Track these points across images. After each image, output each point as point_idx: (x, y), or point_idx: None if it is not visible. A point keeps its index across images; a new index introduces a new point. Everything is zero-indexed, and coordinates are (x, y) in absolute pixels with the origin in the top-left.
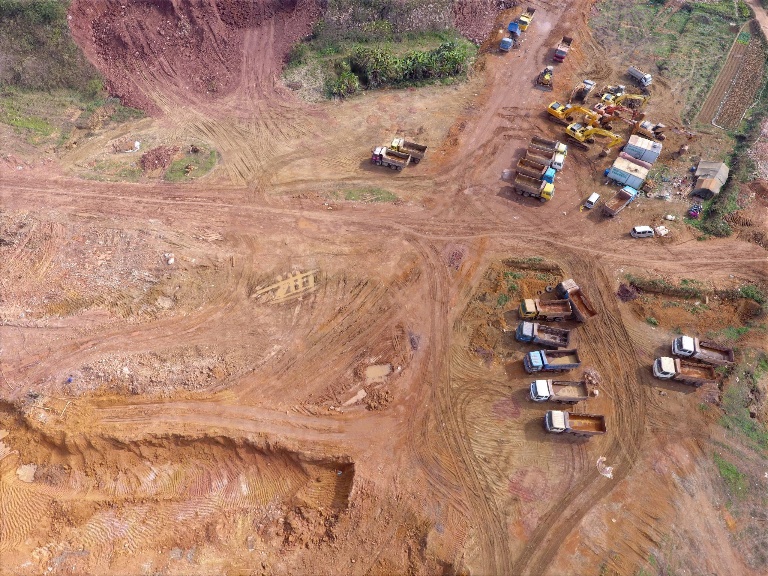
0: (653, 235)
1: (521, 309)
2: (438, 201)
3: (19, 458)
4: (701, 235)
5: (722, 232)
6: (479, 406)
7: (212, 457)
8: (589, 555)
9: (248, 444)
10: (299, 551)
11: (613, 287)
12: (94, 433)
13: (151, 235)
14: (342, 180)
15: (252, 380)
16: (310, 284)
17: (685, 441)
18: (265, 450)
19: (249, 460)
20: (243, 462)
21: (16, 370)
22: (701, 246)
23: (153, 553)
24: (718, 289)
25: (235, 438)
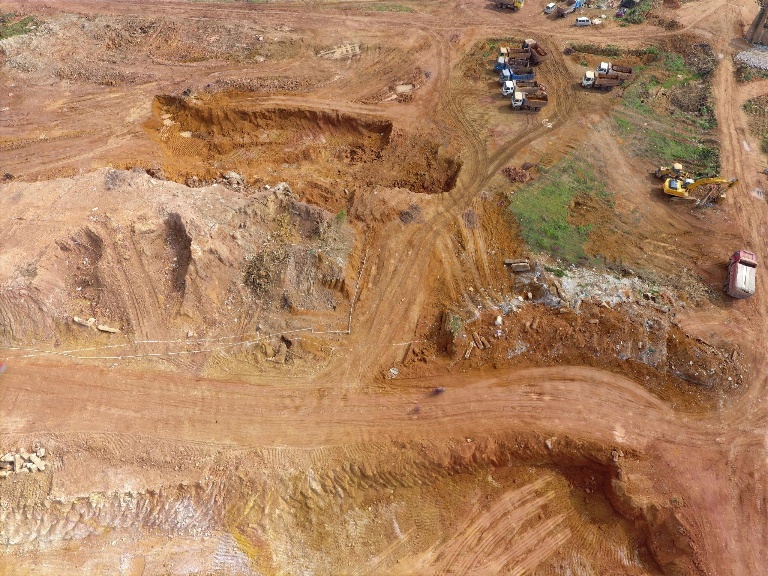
0: (590, 24)
1: (498, 54)
2: (442, 11)
3: (181, 127)
4: (623, 23)
5: (637, 20)
6: (470, 100)
7: (302, 127)
8: (534, 155)
9: (325, 118)
10: (360, 164)
11: (560, 49)
12: (229, 108)
13: (244, 27)
14: (374, 2)
15: (324, 89)
16: (356, 50)
17: (598, 112)
18: (335, 121)
19: (325, 129)
20: (321, 130)
21: (172, 83)
22: (622, 30)
23: (272, 164)
24: (630, 49)
25: (317, 111)
